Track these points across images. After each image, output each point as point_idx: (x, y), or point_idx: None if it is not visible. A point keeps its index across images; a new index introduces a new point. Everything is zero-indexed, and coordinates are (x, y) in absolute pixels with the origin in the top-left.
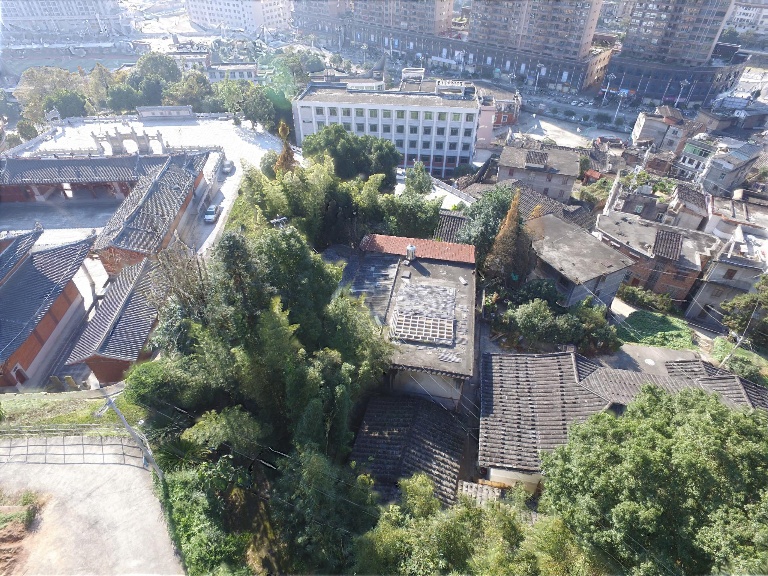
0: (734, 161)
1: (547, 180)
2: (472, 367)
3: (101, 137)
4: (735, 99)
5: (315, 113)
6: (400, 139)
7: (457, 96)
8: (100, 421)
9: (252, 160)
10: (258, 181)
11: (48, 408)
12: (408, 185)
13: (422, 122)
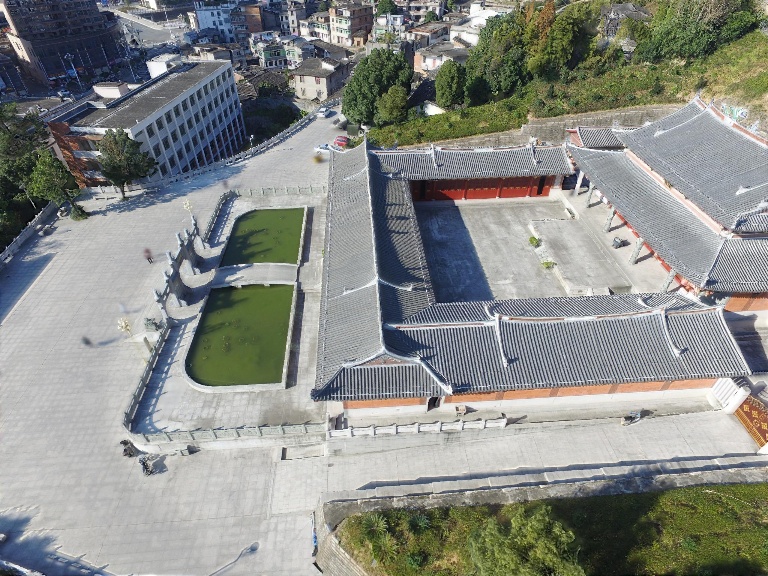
0: (311, 43)
1: (342, 74)
2: (629, 37)
3: (164, 290)
4: (189, 33)
5: (147, 137)
6: (207, 124)
7: (181, 67)
8: (761, 36)
9: (251, 186)
10: (585, 10)
11: (752, 77)
12: (481, 38)
13: (211, 95)
